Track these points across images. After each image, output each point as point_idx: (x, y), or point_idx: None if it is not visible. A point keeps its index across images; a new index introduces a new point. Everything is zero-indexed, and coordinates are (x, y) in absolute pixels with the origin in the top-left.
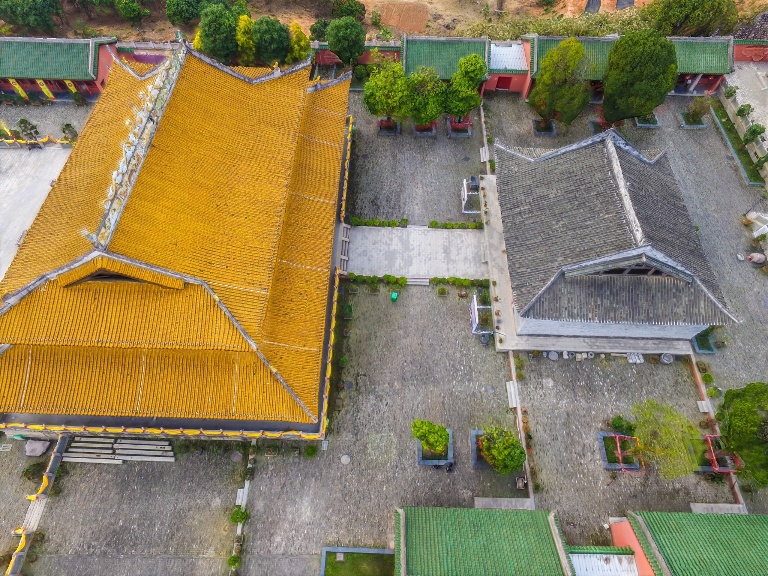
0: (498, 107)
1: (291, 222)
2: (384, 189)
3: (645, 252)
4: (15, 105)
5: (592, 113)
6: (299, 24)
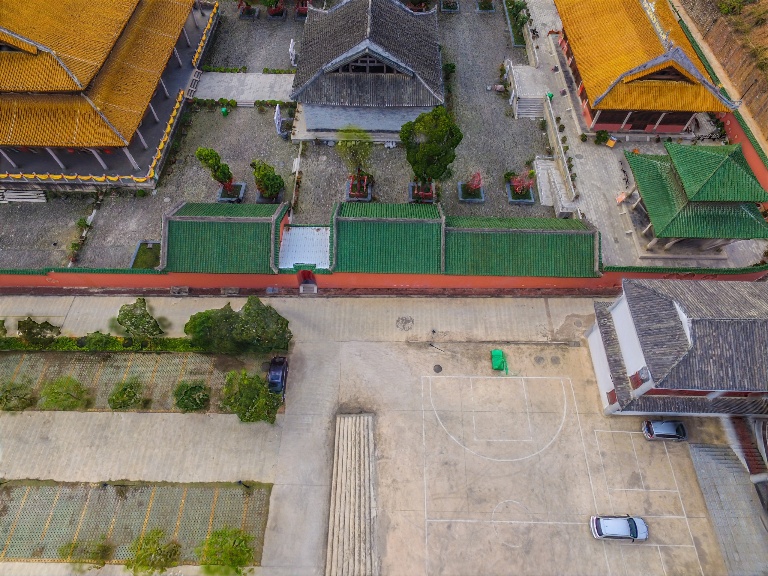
0: (338, 0)
1: (136, 43)
2: (236, 52)
3: (368, 46)
4: None
5: (411, 4)
6: None
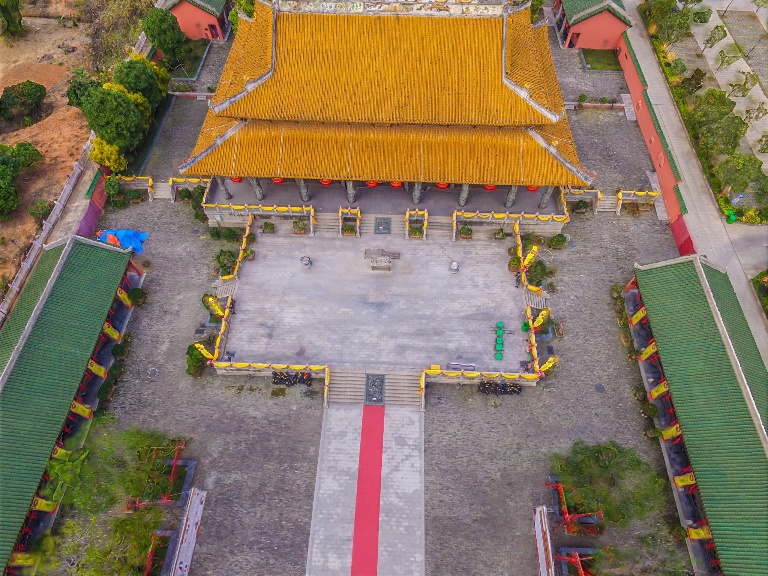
0: None
1: None
2: None
3: None
4: (117, 384)
5: None
6: (32, 135)
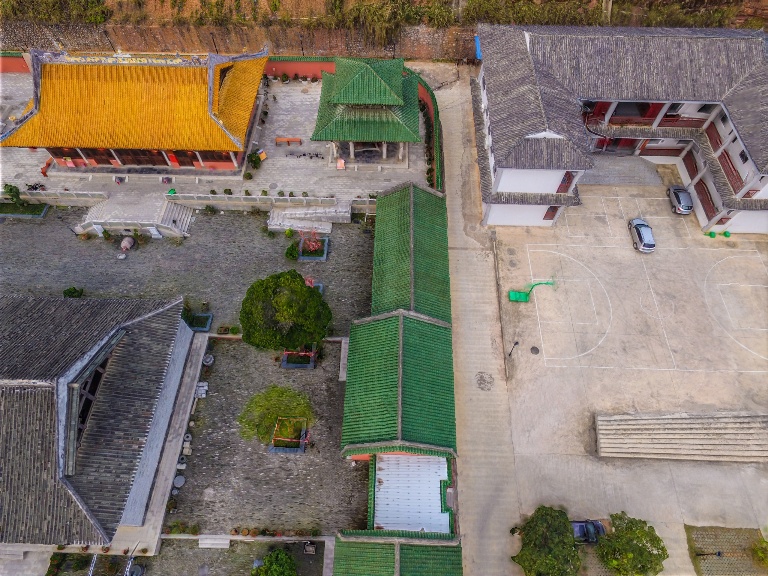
0: None
1: None
2: None
3: (67, 383)
4: None
5: None
6: None
